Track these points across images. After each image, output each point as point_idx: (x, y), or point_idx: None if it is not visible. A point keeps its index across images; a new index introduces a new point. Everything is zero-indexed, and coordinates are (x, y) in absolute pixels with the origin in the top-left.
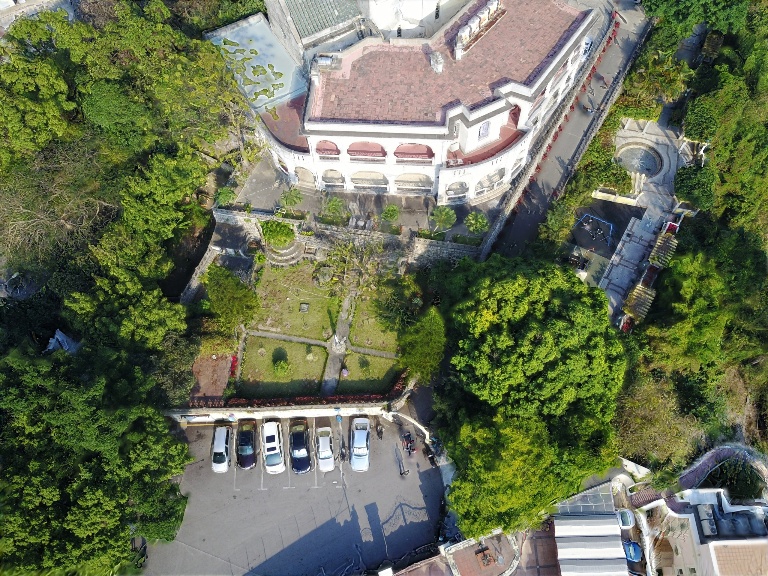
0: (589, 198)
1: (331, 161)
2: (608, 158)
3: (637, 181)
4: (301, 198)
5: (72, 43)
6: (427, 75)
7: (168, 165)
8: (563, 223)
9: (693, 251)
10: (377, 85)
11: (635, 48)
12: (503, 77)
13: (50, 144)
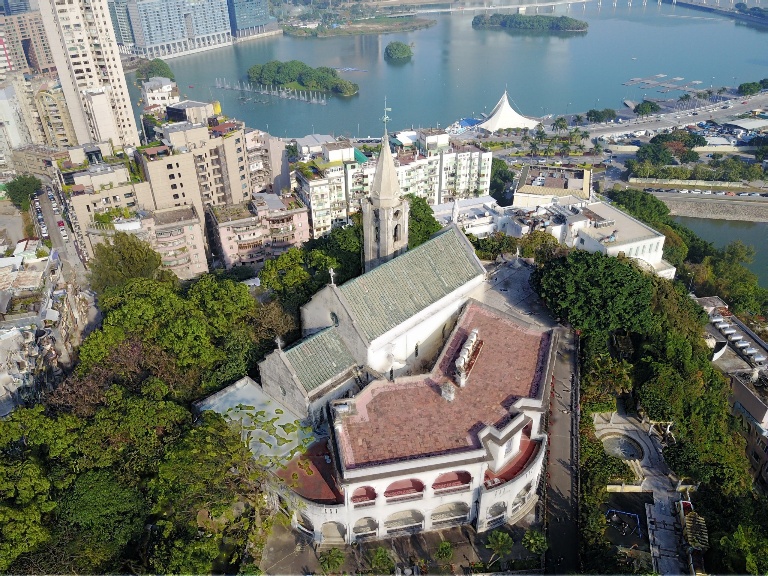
0: (607, 493)
1: (366, 508)
2: (601, 451)
3: (635, 467)
4: (342, 557)
5: (51, 437)
6: (441, 405)
7: (190, 551)
8: (598, 524)
9: (720, 525)
10: (399, 422)
11: (575, 355)
12: (509, 395)
13: (19, 559)
